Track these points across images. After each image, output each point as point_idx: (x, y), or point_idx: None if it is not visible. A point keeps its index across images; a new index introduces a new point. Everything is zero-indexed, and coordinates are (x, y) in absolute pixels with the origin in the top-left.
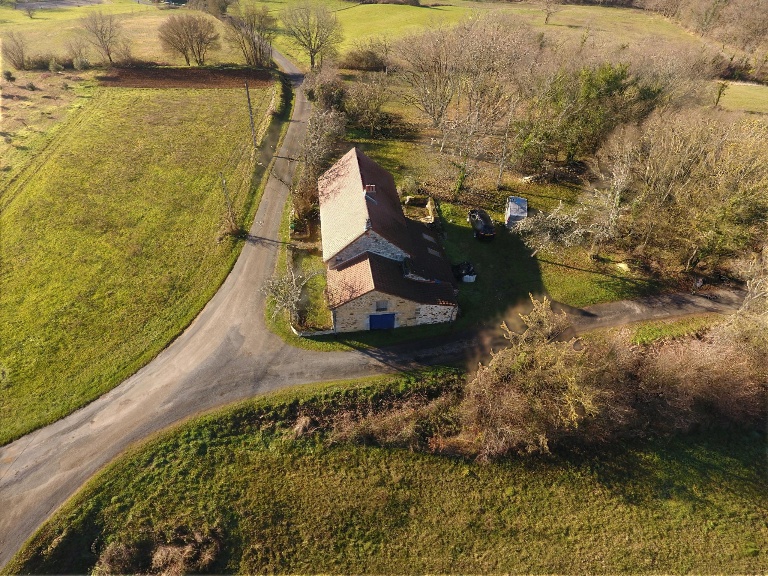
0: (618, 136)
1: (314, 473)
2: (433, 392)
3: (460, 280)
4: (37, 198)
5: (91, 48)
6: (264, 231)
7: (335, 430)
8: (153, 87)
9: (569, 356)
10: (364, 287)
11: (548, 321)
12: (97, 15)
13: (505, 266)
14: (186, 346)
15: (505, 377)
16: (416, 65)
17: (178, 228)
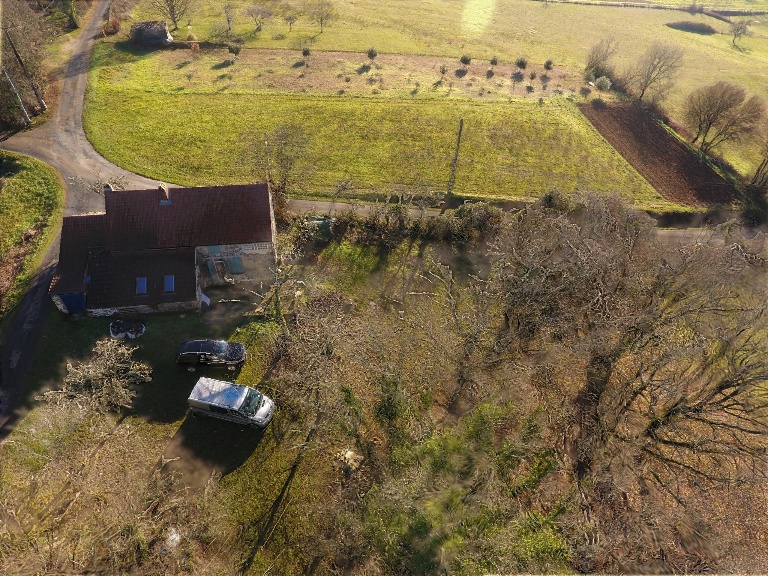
0: None
1: None
2: None
3: None
4: (330, 108)
5: None
6: None
7: None
8: (598, 128)
9: None
10: None
11: None
12: (662, 49)
13: None
14: (132, 180)
15: None
16: None
17: None
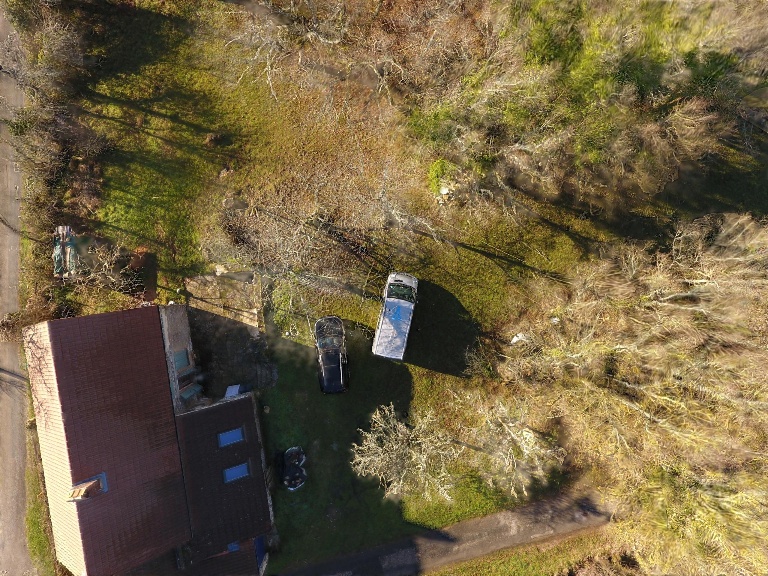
0: None
1: None
2: None
3: None
4: None
5: None
6: None
7: None
8: None
9: None
10: None
11: None
12: None
13: None
14: None
15: None
16: None
17: None
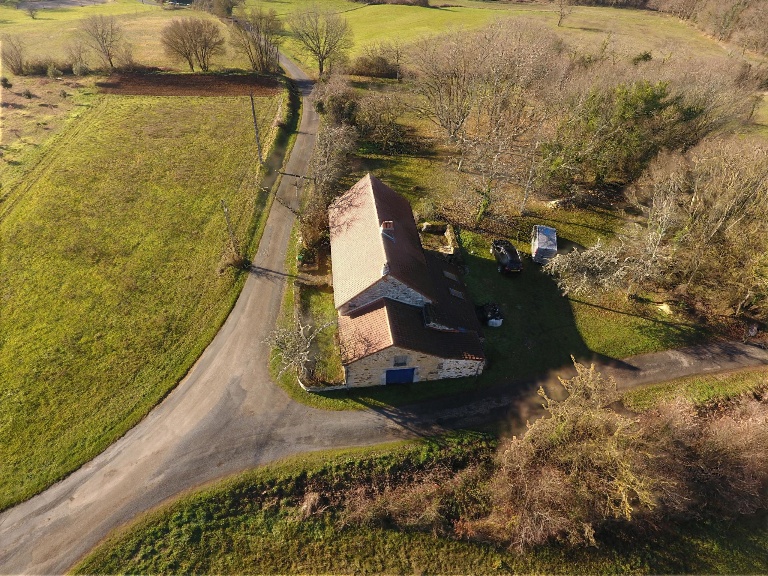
0: (655, 160)
1: (324, 565)
2: (458, 462)
3: (485, 324)
4: (26, 221)
5: (92, 52)
6: (269, 261)
7: (347, 509)
8: (155, 94)
9: (621, 437)
10: (381, 341)
11: (597, 395)
12: (98, 19)
13: (534, 307)
14: (181, 402)
15: (543, 452)
16: (432, 77)
17: (176, 257)
